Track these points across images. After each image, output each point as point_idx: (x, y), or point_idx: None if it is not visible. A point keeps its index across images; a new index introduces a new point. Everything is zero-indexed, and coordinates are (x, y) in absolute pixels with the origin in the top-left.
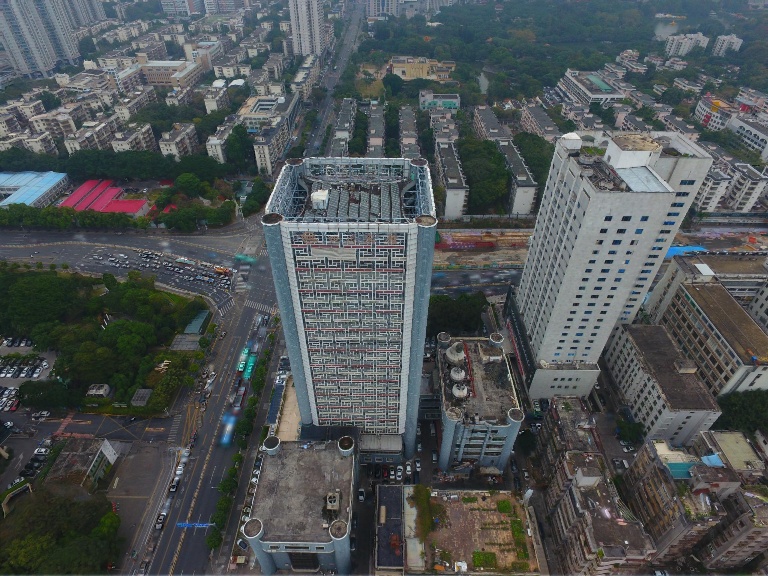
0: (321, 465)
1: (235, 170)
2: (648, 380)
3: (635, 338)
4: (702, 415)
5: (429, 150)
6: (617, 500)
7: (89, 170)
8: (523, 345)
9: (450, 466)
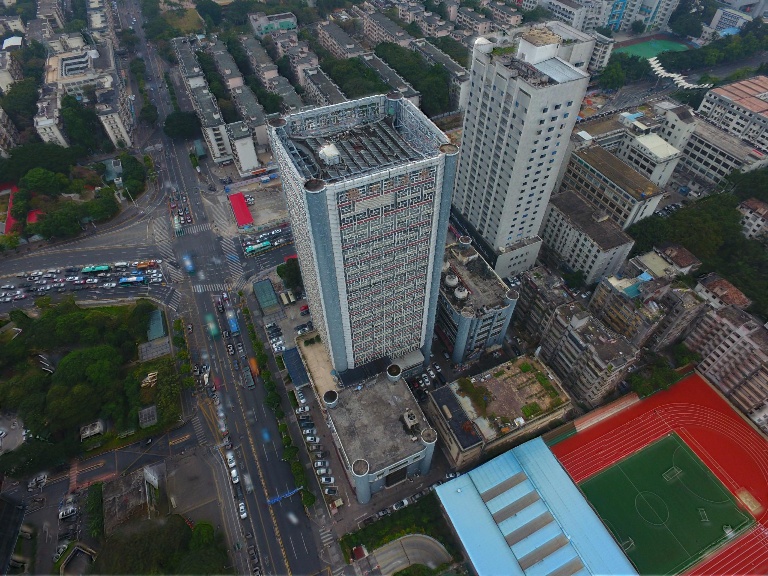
0: (381, 397)
1: (86, 151)
2: (580, 235)
3: (558, 206)
4: (622, 248)
5: (291, 80)
6: (603, 328)
7: None
8: (475, 240)
9: (465, 357)
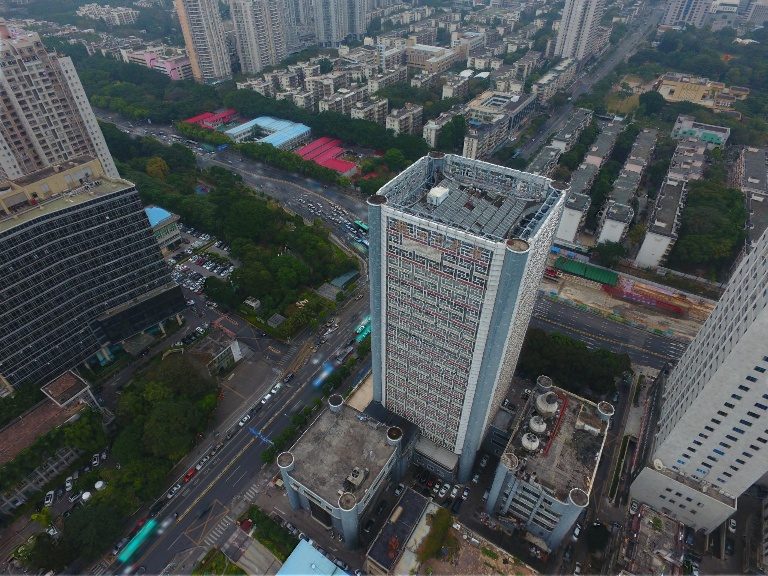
0: (366, 441)
1: None
2: None
3: None
4: None
5: (657, 184)
6: None
7: (326, 129)
8: (648, 433)
9: (495, 512)
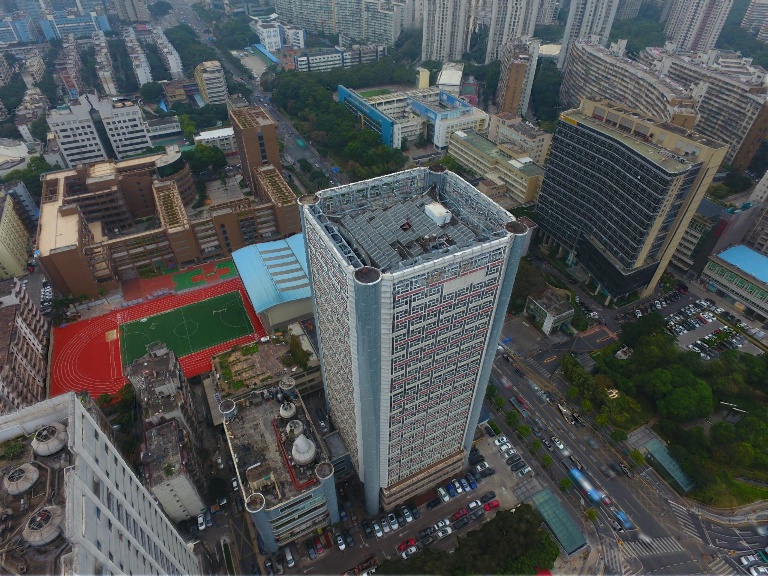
0: None
1: None
2: None
3: None
4: None
5: None
6: (143, 387)
7: None
8: None
9: None
